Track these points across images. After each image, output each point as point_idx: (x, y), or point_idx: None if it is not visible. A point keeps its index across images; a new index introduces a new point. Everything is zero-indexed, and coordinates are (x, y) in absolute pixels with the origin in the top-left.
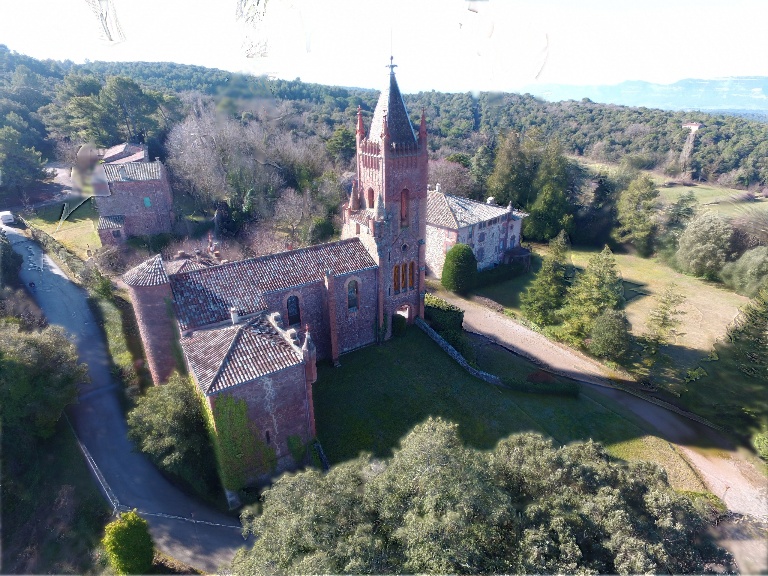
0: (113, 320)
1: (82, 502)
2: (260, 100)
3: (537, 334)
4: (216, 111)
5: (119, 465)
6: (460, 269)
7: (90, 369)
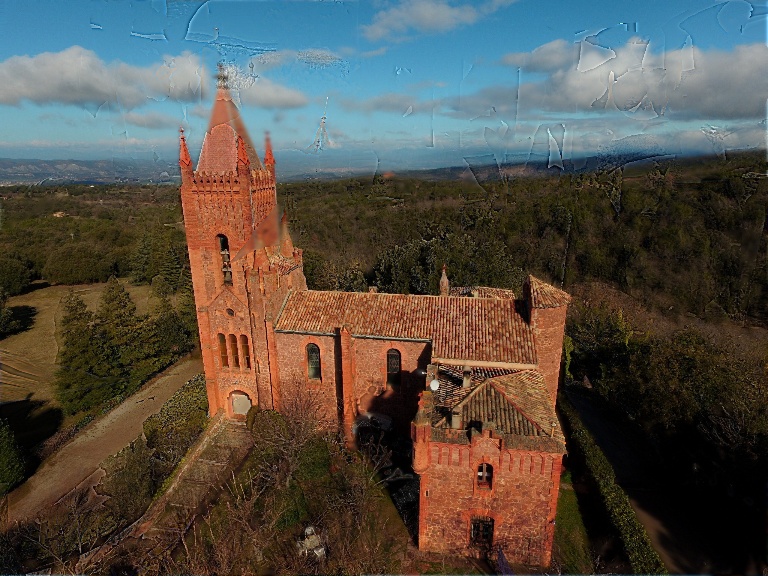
0: (653, 575)
1: (605, 408)
2: (323, 103)
3: (129, 400)
4: (428, 121)
5: (583, 416)
6: (12, 434)
7: (663, 527)
